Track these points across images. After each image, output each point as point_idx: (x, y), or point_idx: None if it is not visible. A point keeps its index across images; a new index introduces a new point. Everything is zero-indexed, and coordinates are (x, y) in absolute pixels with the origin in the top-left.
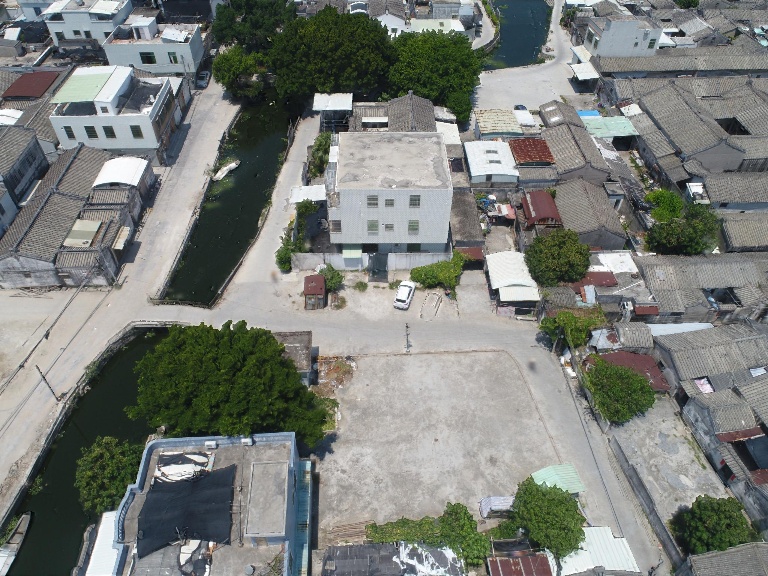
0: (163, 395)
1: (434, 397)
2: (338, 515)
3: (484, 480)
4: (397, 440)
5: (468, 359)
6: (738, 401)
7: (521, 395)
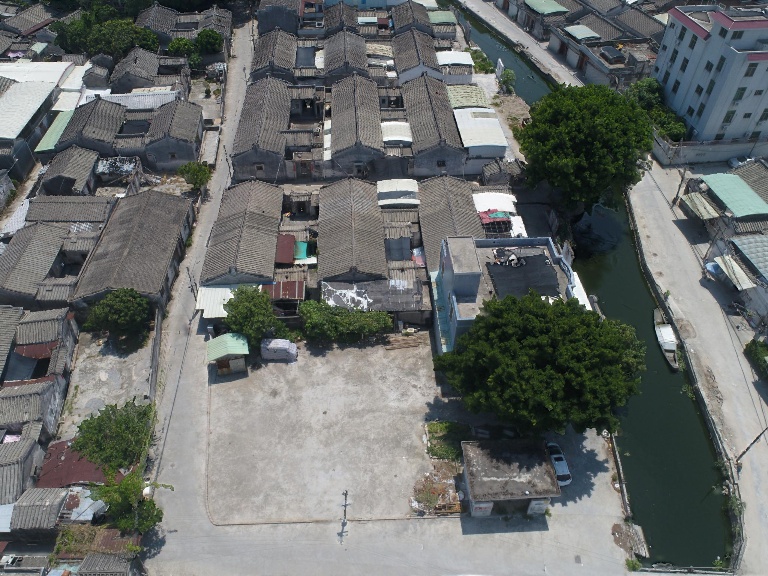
0: (579, 305)
1: (320, 459)
2: (416, 354)
3: (287, 378)
4: (364, 413)
5: (267, 512)
6: (1, 404)
7: (219, 461)
